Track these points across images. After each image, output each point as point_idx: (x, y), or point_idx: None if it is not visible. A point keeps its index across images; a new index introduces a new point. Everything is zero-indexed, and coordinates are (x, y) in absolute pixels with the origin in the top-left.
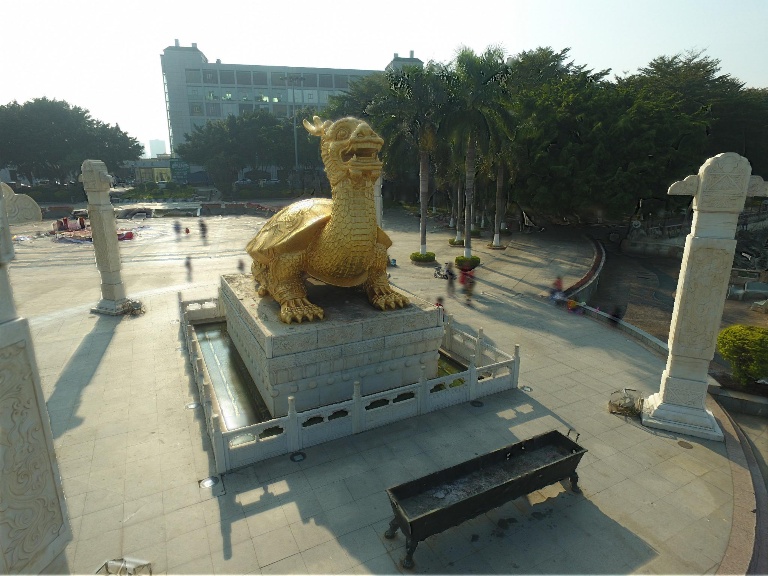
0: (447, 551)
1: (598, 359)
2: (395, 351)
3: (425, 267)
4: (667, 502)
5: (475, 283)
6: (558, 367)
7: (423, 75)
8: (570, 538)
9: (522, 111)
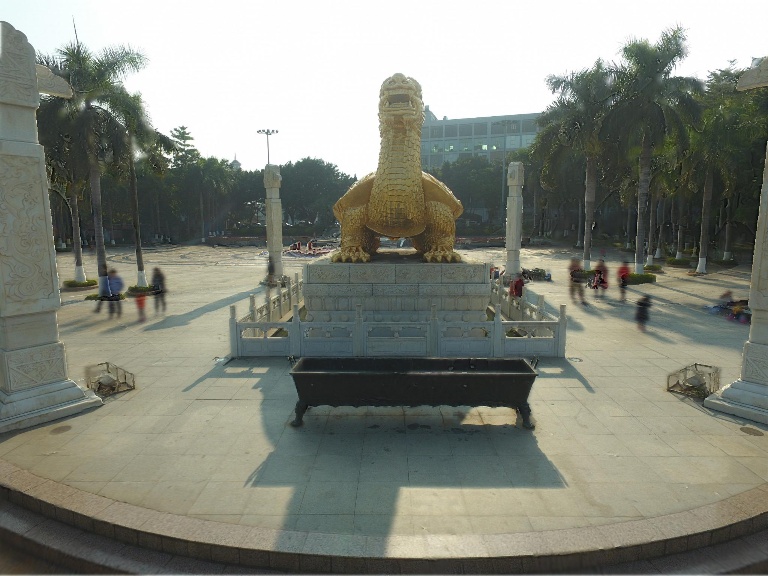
0: (338, 426)
1: (716, 354)
2: (431, 301)
3: (583, 283)
4: (642, 460)
5: (625, 293)
6: (643, 352)
7: (588, 75)
8: (471, 450)
9: (757, 113)
